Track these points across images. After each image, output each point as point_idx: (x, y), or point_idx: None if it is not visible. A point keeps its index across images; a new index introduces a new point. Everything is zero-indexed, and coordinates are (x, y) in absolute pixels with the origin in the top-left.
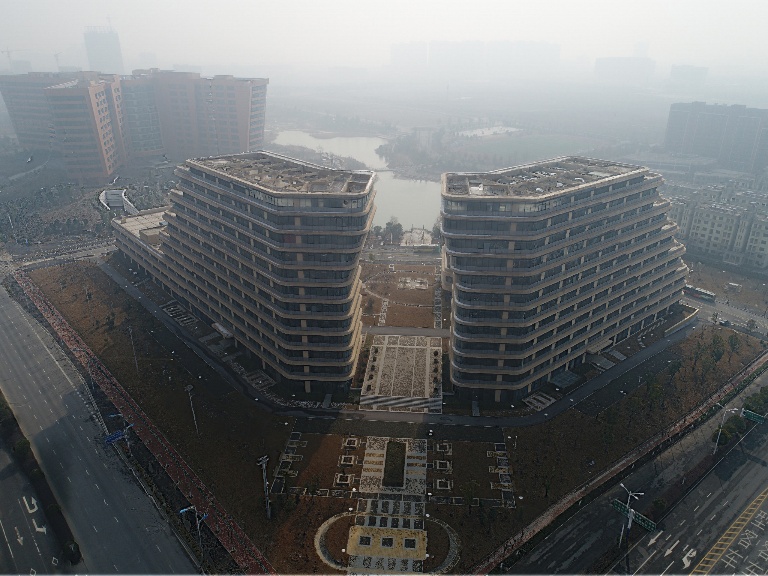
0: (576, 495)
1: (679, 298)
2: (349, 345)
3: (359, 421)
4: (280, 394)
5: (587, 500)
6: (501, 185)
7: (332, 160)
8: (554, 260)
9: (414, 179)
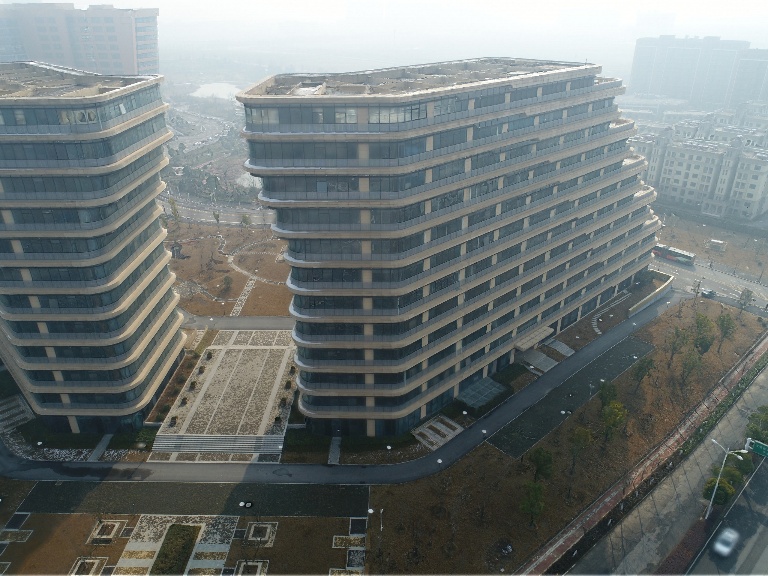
0: None
1: (648, 262)
2: (127, 359)
3: (138, 484)
4: None
5: None
6: (355, 86)
7: None
8: (446, 210)
9: None
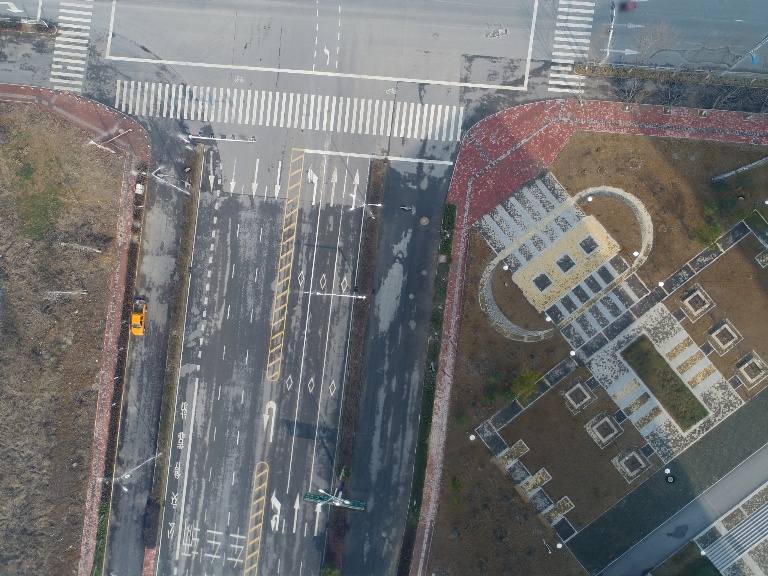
0: (428, 517)
1: None
2: None
3: None
4: None
5: None
6: None
7: None
8: None
9: None
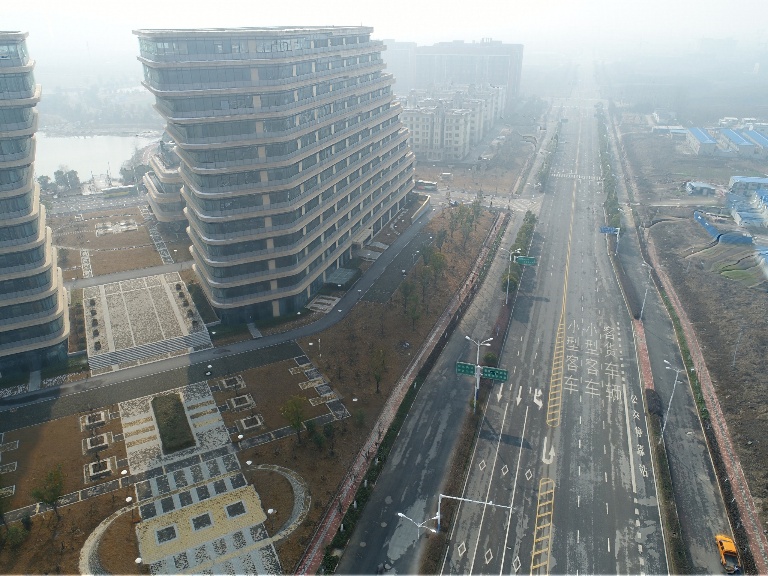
0: (406, 380)
1: (412, 186)
2: (50, 288)
3: (97, 389)
4: None
5: (420, 381)
6: None
7: None
8: (307, 124)
9: (75, 136)
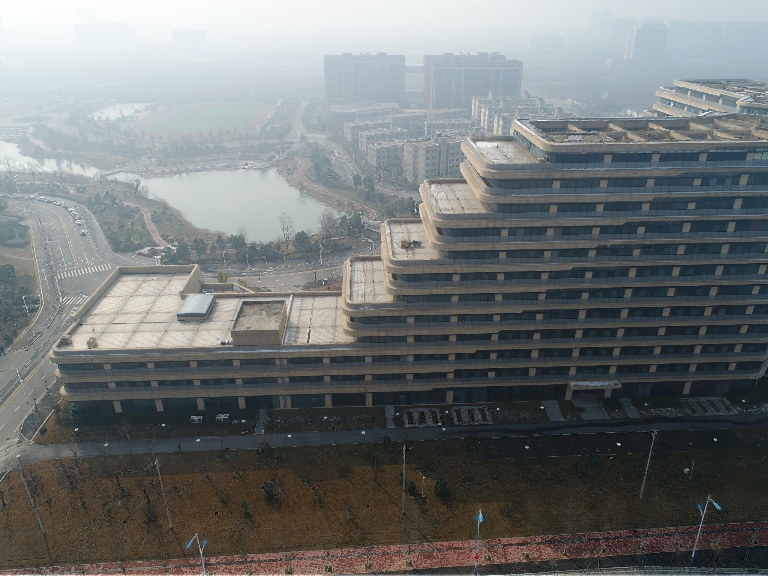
0: None
1: None
2: None
3: None
4: (756, 401)
5: None
6: None
7: (33, 174)
8: None
9: (172, 174)
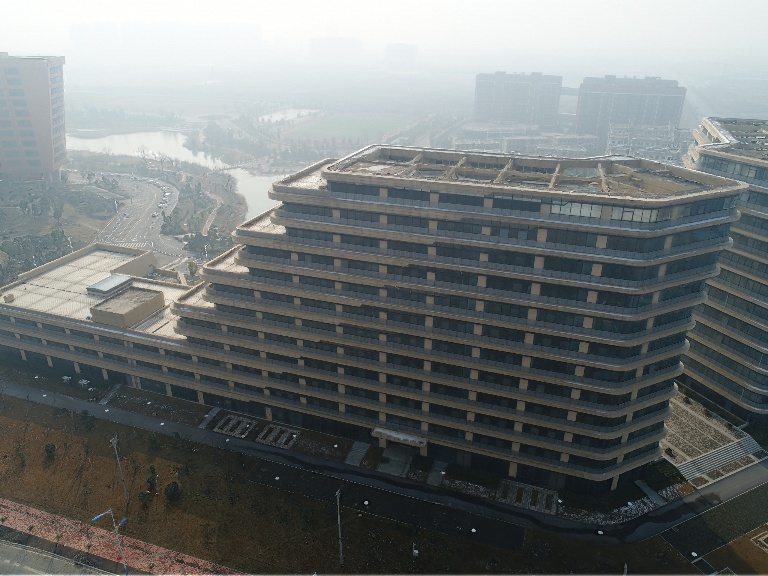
0: None
1: None
2: (669, 405)
3: (725, 505)
4: (589, 508)
5: None
6: None
7: (162, 162)
8: None
9: (277, 174)
